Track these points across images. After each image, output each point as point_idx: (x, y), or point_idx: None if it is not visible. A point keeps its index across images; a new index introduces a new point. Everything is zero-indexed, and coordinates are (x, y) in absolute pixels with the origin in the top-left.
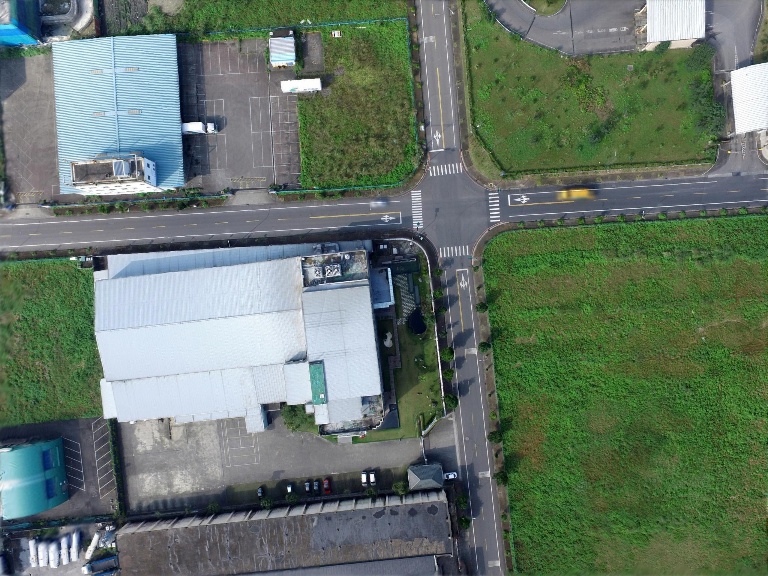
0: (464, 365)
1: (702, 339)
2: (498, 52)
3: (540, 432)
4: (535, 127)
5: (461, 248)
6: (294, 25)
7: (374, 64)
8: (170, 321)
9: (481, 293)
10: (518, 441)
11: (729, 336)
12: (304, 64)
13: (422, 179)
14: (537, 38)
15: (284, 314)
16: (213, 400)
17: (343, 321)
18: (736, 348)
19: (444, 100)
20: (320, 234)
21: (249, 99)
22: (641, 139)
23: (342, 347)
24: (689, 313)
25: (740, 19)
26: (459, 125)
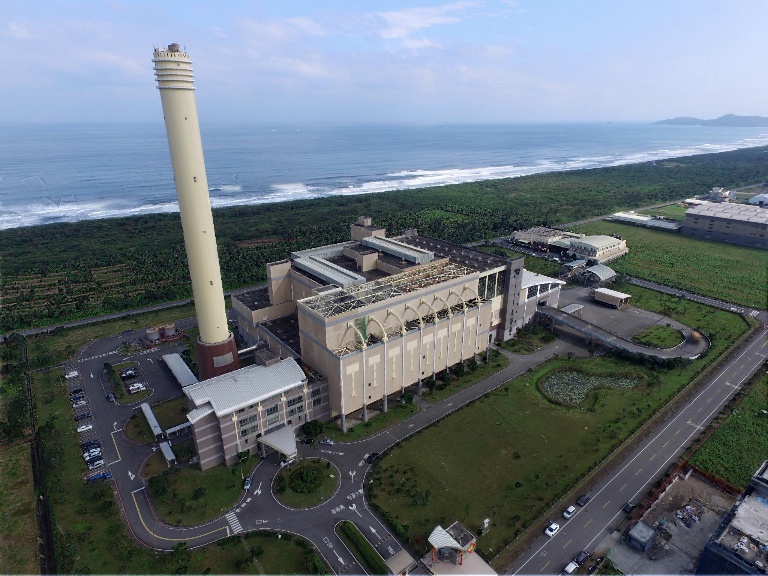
0: None
1: None
2: (713, 333)
3: None
4: None
5: None
6: None
7: None
8: None
9: None
10: None
11: None
12: None
13: None
14: (684, 326)
15: None
16: None
17: None
18: None
19: (765, 340)
20: None
21: None
22: None
23: None
24: None
25: None
26: None
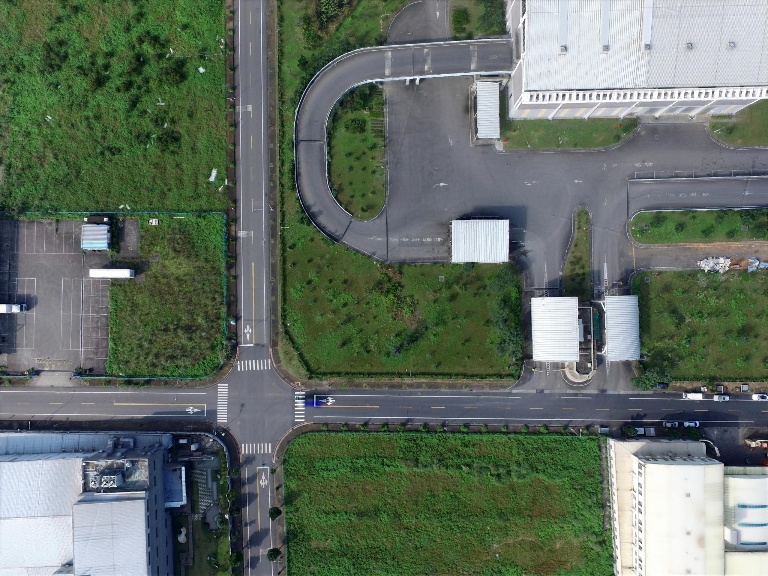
0: (258, 565)
1: (496, 556)
2: (313, 252)
3: None
4: (344, 330)
5: (264, 446)
6: (112, 210)
7: (189, 255)
8: None
9: (280, 493)
10: None
11: (523, 555)
12: (120, 249)
13: (230, 373)
14: (352, 242)
15: (60, 519)
16: None
17: (114, 535)
18: (529, 568)
19: (257, 295)
20: (123, 421)
21: (62, 280)
22: (448, 350)
23: (111, 562)
24: (485, 529)
25: (551, 239)
26: (271, 321)
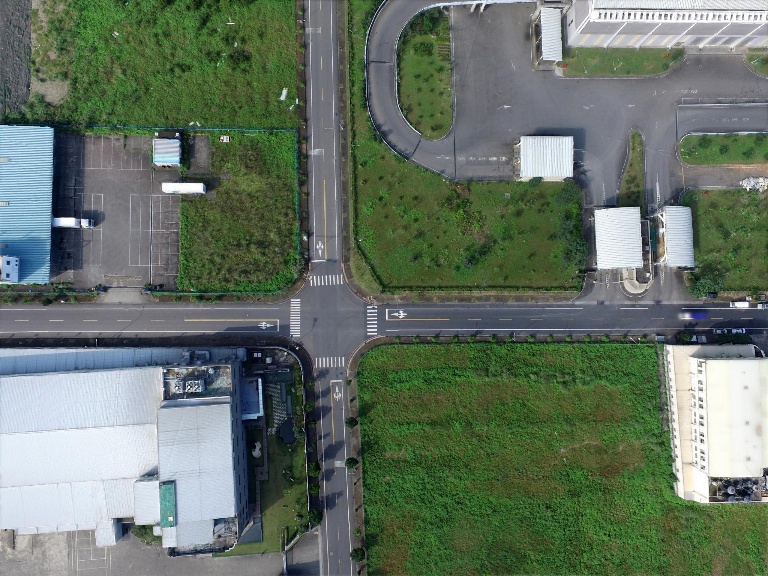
0: (333, 478)
1: (563, 460)
2: (384, 170)
3: (405, 549)
4: (415, 245)
5: (337, 359)
6: (182, 126)
7: (261, 172)
8: (15, 430)
9: (354, 405)
10: (382, 557)
11: (588, 458)
12: (190, 165)
13: (302, 288)
14: (421, 160)
15: (140, 428)
16: (60, 512)
17: (200, 440)
18: (594, 470)
19: (329, 212)
20: (194, 337)
21: (130, 196)
22: (514, 264)
23: (197, 467)
24: (552, 434)
25: (608, 159)
26: (342, 237)
